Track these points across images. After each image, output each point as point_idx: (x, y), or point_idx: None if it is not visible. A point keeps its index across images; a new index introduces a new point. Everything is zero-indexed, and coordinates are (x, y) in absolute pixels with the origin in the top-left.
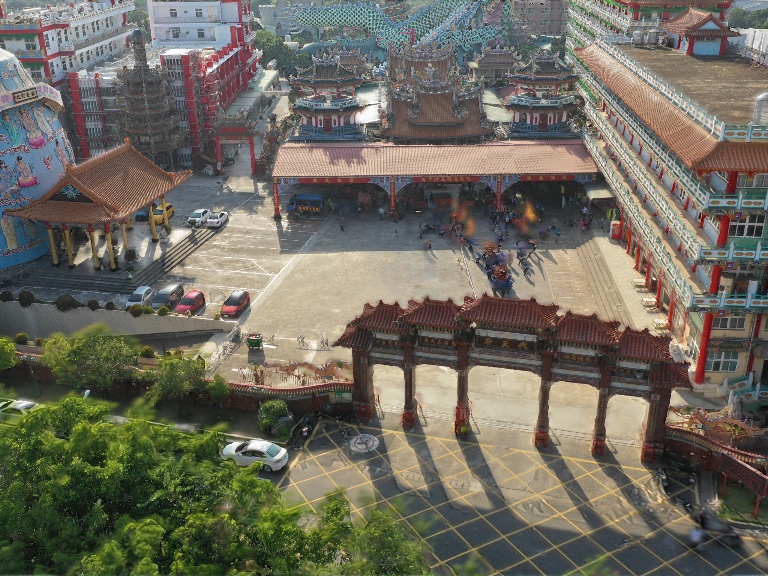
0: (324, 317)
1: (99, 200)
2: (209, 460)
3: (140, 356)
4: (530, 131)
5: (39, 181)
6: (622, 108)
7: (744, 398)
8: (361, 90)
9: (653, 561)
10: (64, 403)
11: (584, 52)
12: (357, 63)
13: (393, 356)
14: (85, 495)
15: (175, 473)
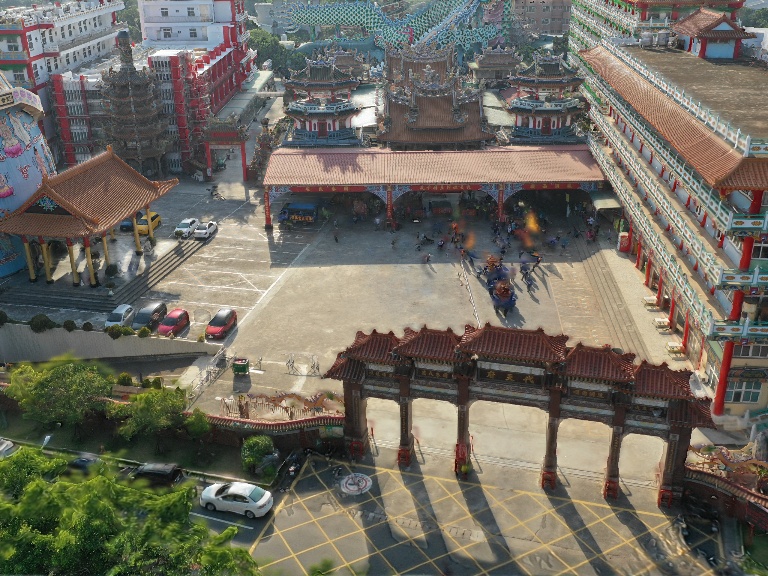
0: (315, 338)
1: (77, 212)
2: (176, 526)
3: (117, 384)
4: (533, 136)
5: (15, 191)
6: (632, 115)
7: (767, 432)
8: (358, 92)
9: None
10: (14, 459)
11: (590, 54)
12: (354, 64)
13: (388, 389)
14: (34, 569)
15: (136, 543)
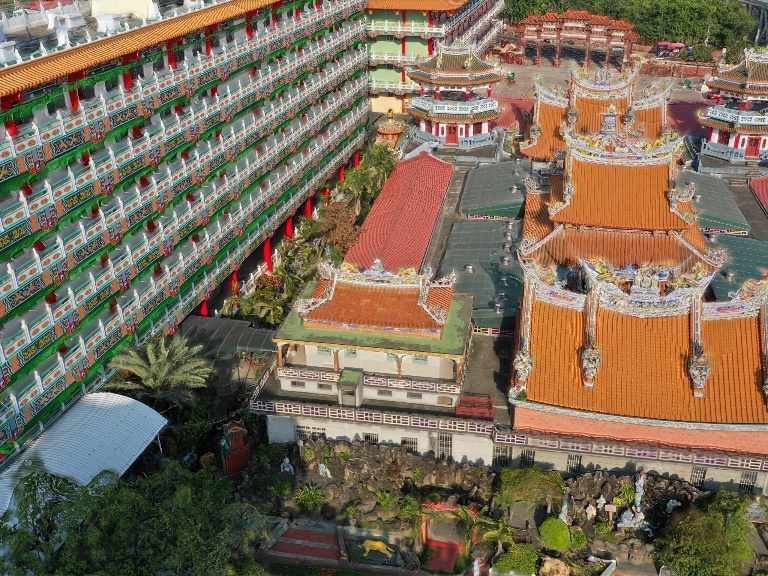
0: None
1: None
2: None
3: None
4: None
5: None
6: None
7: None
8: None
9: None
10: None
11: (457, 2)
12: None
13: None
14: None
15: None
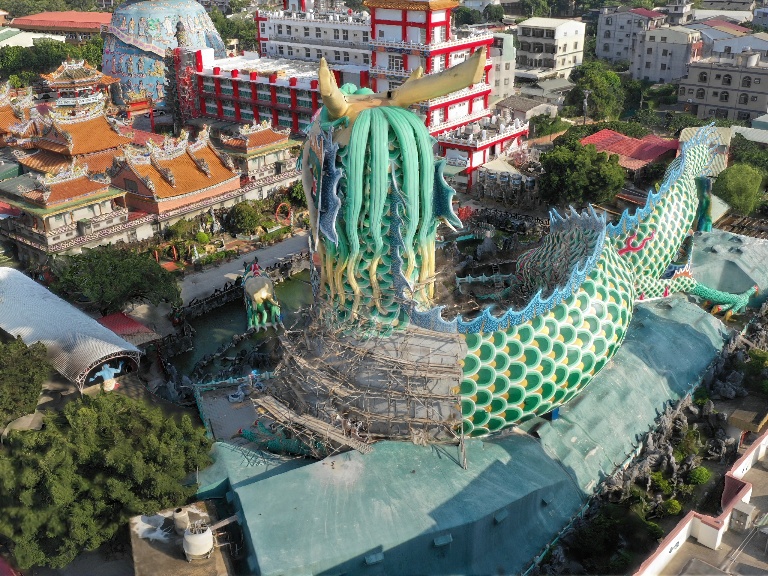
0: None
1: None
2: None
3: None
4: None
5: None
6: None
7: None
8: None
9: None
10: None
11: None
12: None
13: None
14: None
15: None
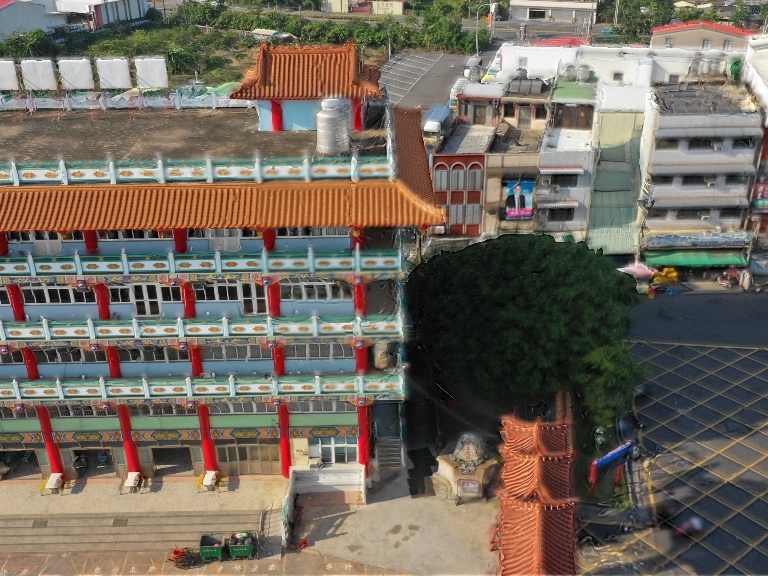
0: None
1: None
2: None
3: None
4: None
5: None
6: None
7: None
8: None
9: (733, 574)
10: None
11: None
12: None
13: None
14: None
15: None
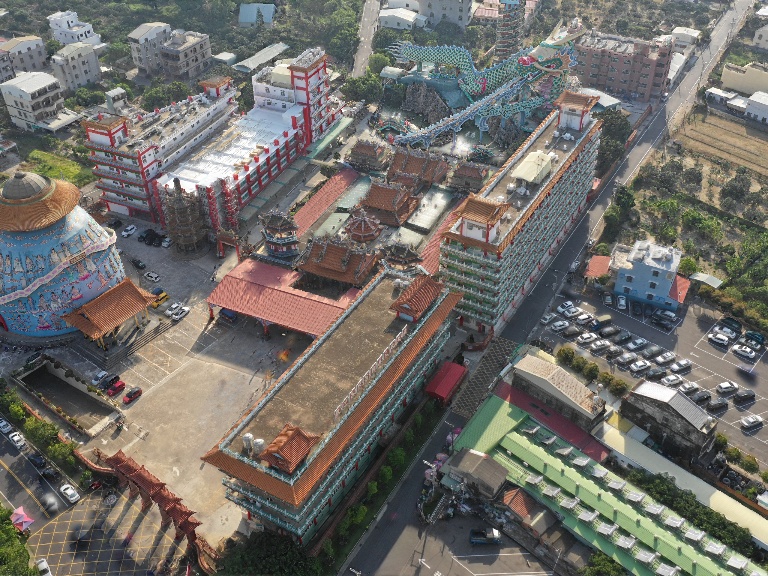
0: (162, 416)
1: (95, 323)
2: (2, 520)
3: None
4: None
5: (84, 295)
6: None
7: None
8: (365, 179)
9: None
10: None
11: None
12: (372, 154)
13: None
14: None
15: None
